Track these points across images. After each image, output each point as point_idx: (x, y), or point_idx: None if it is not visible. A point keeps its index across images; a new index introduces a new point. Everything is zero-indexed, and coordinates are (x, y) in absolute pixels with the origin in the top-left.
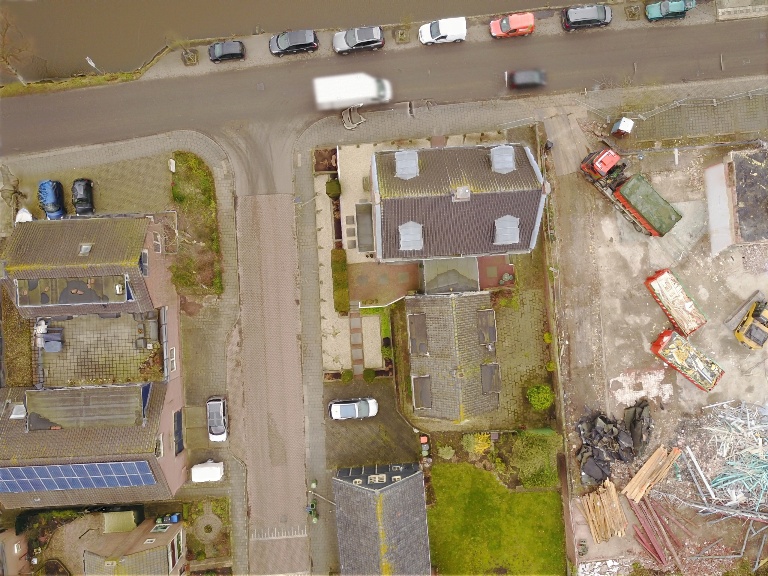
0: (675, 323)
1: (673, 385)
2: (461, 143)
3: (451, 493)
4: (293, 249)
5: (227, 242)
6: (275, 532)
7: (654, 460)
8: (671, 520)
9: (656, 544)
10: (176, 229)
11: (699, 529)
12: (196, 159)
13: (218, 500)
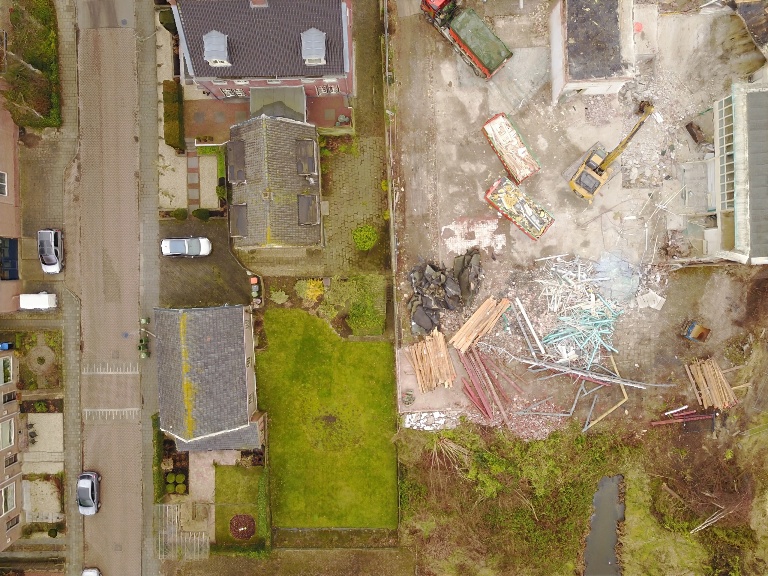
0: (509, 170)
1: (506, 236)
2: None
3: (283, 338)
4: (133, 85)
5: (68, 75)
6: (107, 367)
7: (482, 310)
8: (501, 375)
9: (483, 397)
10: (4, 49)
11: (529, 386)
12: None
13: (51, 332)
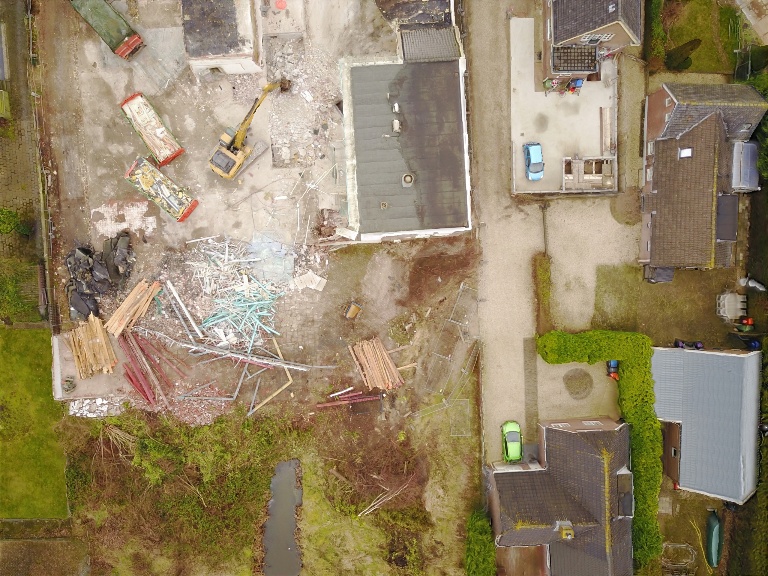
0: None
1: (156, 218)
2: None
3: None
4: None
5: None
6: None
7: (134, 294)
8: (163, 360)
9: (143, 382)
10: None
11: (192, 370)
12: None
13: None
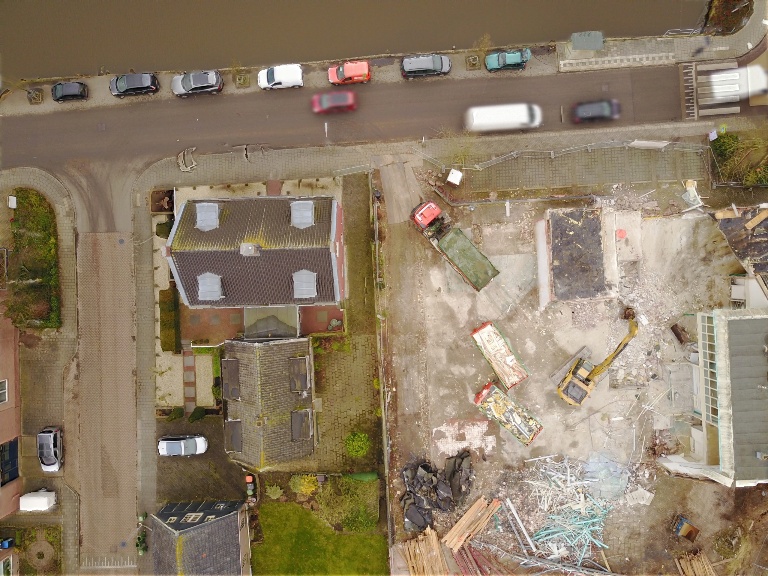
0: (498, 376)
1: (496, 437)
2: (296, 188)
3: (278, 532)
4: (131, 286)
5: (67, 277)
6: (105, 561)
7: (474, 511)
8: (493, 570)
9: None
10: (5, 266)
11: None
12: (37, 196)
13: (51, 528)
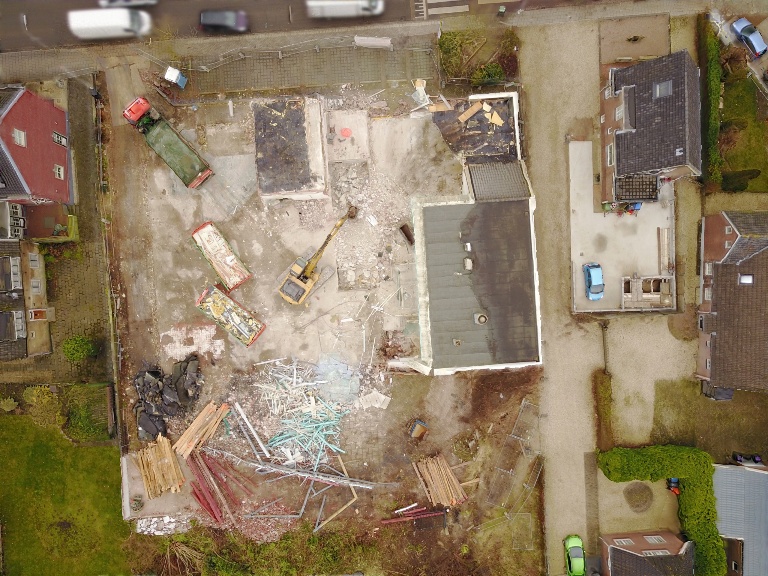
0: None
1: (225, 341)
2: None
3: (14, 445)
4: None
5: None
6: None
7: (203, 416)
8: (230, 478)
9: (210, 501)
10: None
11: (258, 488)
12: None
13: None
